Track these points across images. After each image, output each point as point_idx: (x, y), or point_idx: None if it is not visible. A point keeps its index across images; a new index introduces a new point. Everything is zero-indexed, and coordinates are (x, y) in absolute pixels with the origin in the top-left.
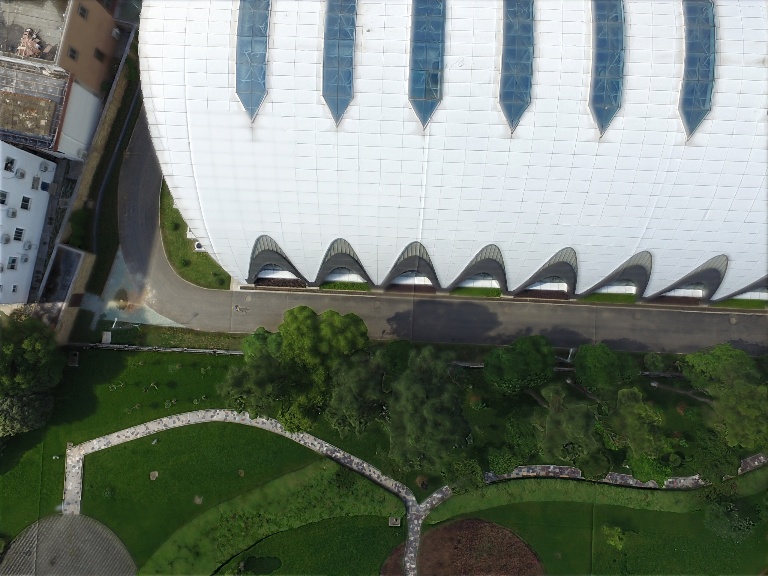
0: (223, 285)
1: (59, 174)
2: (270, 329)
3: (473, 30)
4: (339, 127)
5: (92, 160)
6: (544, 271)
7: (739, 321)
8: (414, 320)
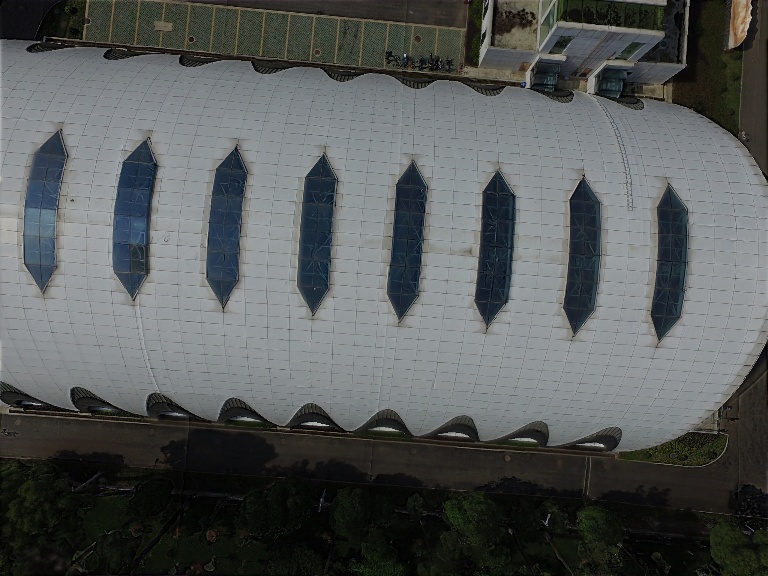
0: None
1: None
2: (39, 454)
3: (181, 205)
4: (45, 294)
5: None
6: (300, 418)
7: (514, 459)
8: (188, 449)
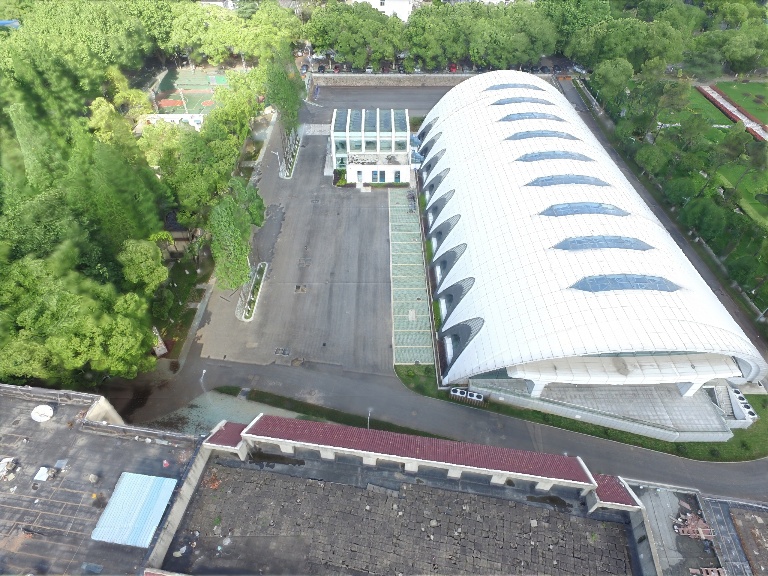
0: None
1: None
2: None
3: None
4: None
5: None
6: None
7: None
8: None
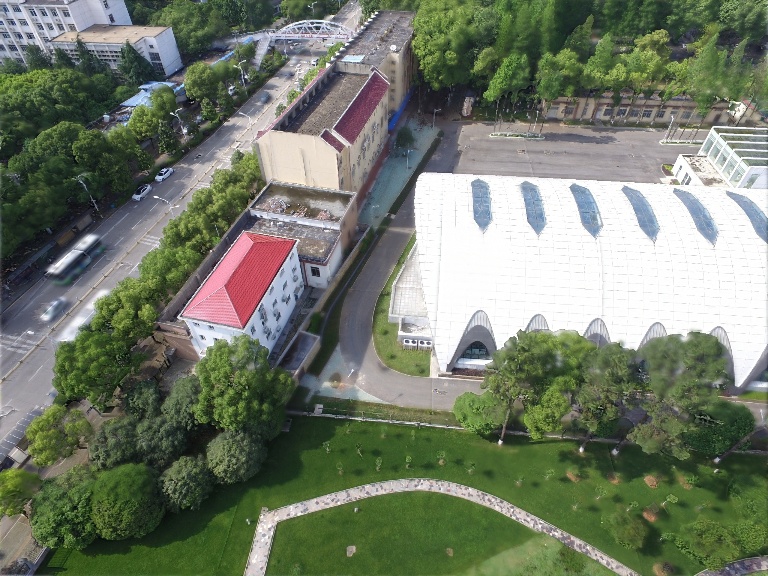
0: (423, 373)
1: (304, 295)
2: None
3: (611, 199)
4: (540, 237)
5: (332, 286)
6: None
7: None
8: None
